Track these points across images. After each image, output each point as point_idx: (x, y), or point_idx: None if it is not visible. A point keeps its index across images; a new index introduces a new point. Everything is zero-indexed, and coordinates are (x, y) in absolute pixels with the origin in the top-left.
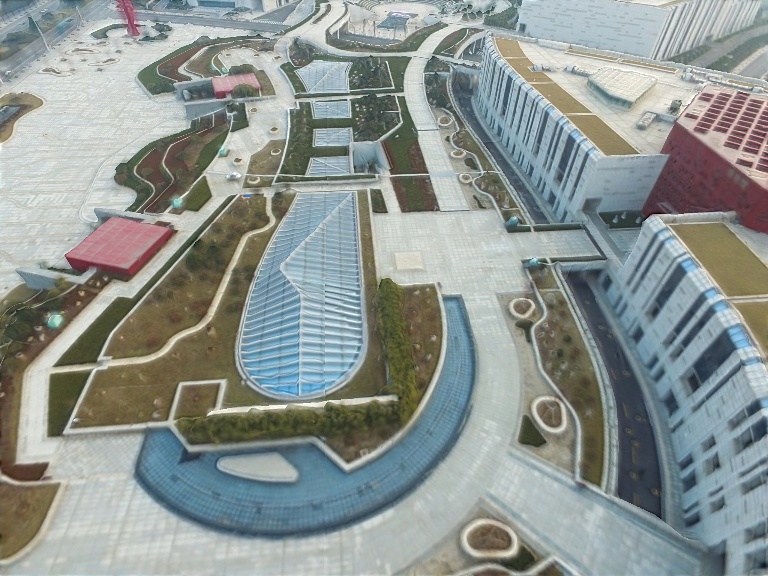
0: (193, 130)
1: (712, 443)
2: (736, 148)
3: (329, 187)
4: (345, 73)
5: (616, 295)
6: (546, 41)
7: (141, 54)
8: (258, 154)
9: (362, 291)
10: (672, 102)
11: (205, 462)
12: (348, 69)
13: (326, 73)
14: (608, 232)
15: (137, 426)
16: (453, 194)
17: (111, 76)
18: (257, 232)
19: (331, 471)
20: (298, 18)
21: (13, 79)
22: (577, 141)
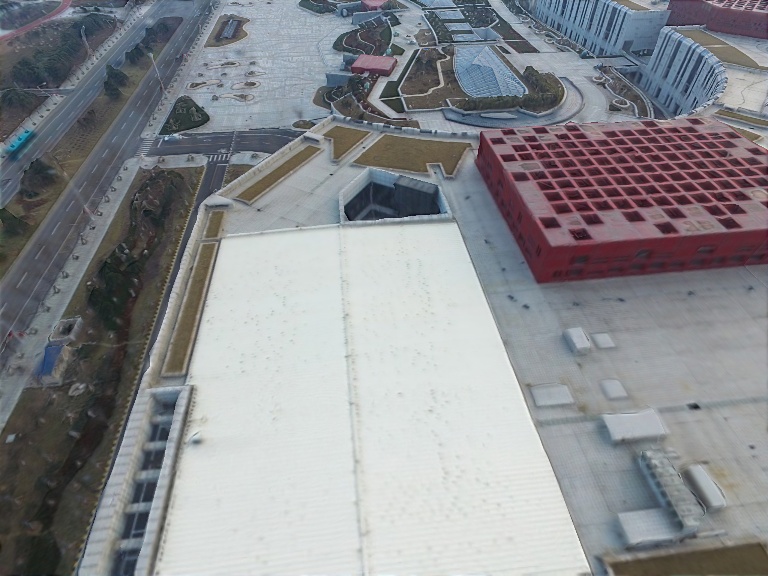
0: (363, 28)
1: (695, 100)
2: None
3: (471, 45)
4: None
5: (645, 81)
6: None
7: None
8: (417, 35)
9: (515, 75)
10: None
11: (474, 116)
12: None
13: None
14: (638, 58)
15: (437, 109)
16: (545, 47)
17: (280, 6)
18: (443, 60)
19: (530, 117)
20: None
21: (216, 8)
22: (619, 8)
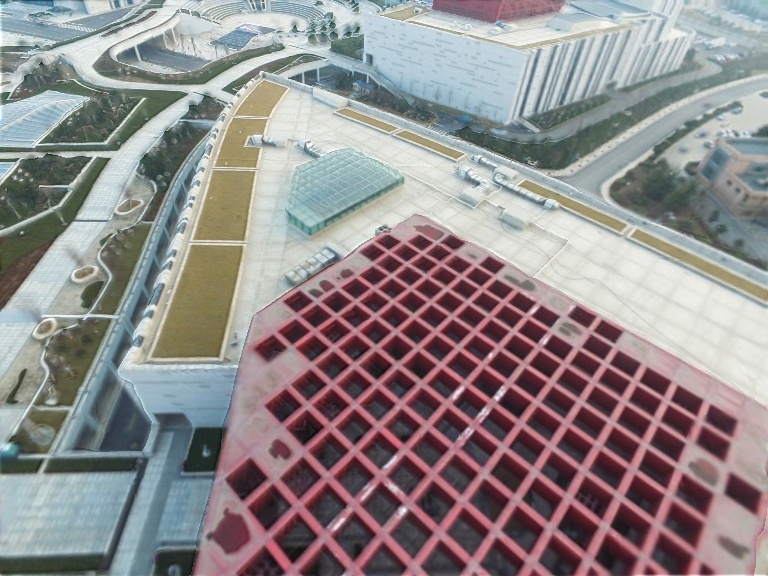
0: None
1: None
2: (282, 416)
3: None
4: (65, 114)
5: None
6: (320, 92)
7: None
8: None
9: None
10: (376, 231)
11: None
12: (76, 108)
13: (25, 115)
14: (174, 481)
15: None
16: None
17: None
18: None
19: None
20: None
21: None
22: None
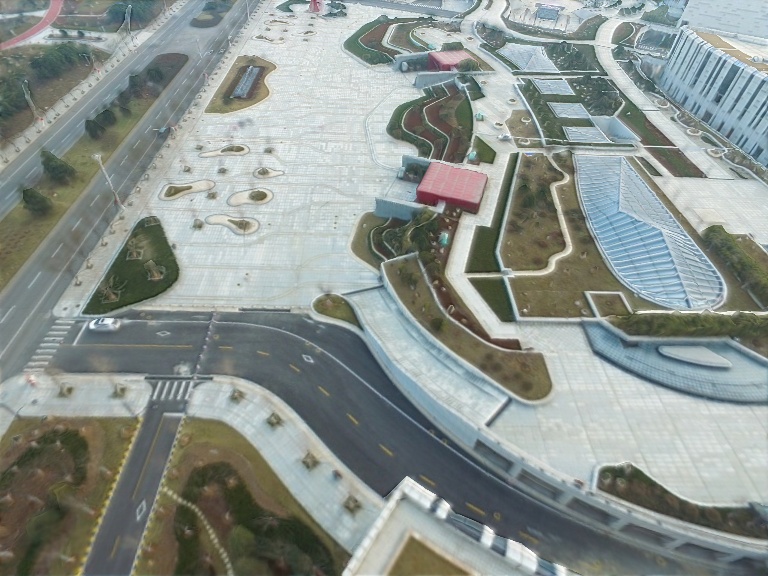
0: (430, 97)
1: None
2: None
3: (596, 152)
4: (544, 56)
5: None
6: (747, 36)
7: (332, 28)
8: (510, 121)
9: (688, 235)
10: None
11: (645, 349)
12: (544, 52)
13: (532, 54)
14: None
15: (573, 319)
16: (711, 165)
17: (319, 46)
18: (560, 183)
19: (753, 364)
20: (452, 4)
21: (235, 43)
22: None
